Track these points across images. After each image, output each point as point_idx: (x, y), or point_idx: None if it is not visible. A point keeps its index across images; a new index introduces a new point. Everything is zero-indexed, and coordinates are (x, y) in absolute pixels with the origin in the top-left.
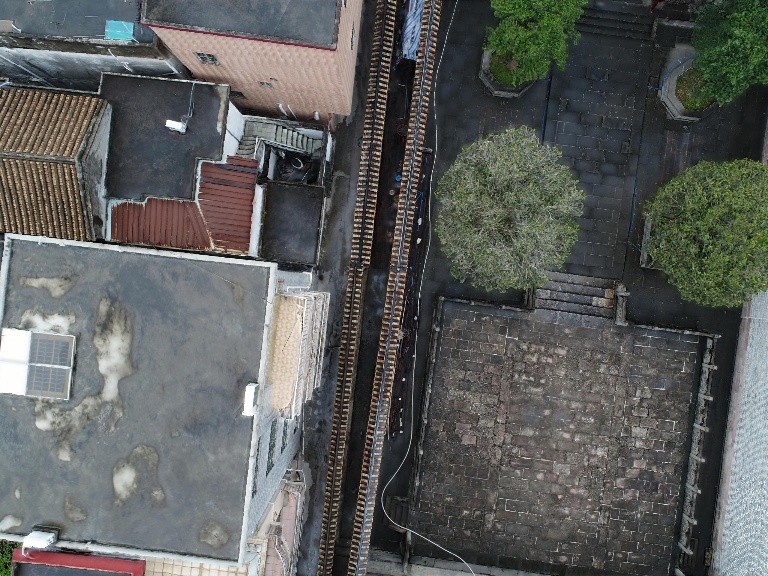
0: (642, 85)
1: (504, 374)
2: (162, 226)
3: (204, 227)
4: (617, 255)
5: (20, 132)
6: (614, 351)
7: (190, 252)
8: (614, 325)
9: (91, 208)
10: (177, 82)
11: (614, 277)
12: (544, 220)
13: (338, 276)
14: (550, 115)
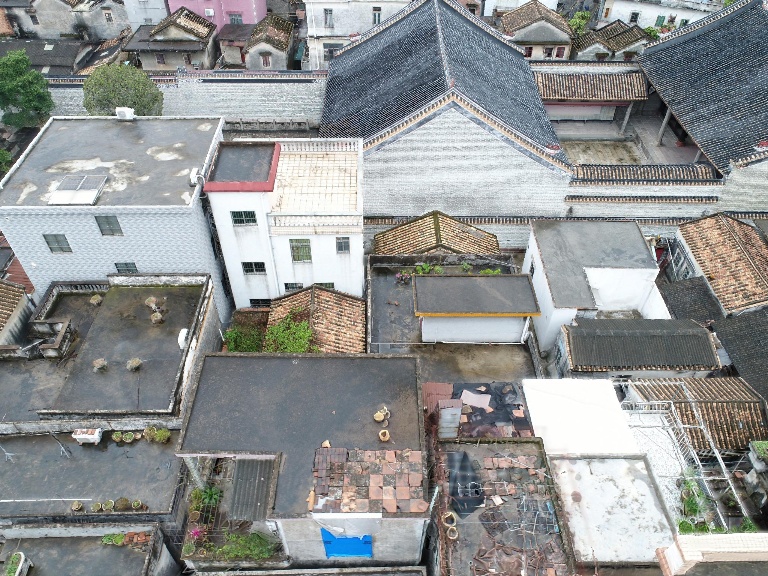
0: None
1: None
2: None
3: None
4: None
5: None
6: None
7: None
8: None
9: None
10: None
11: None
12: None
13: None
14: None
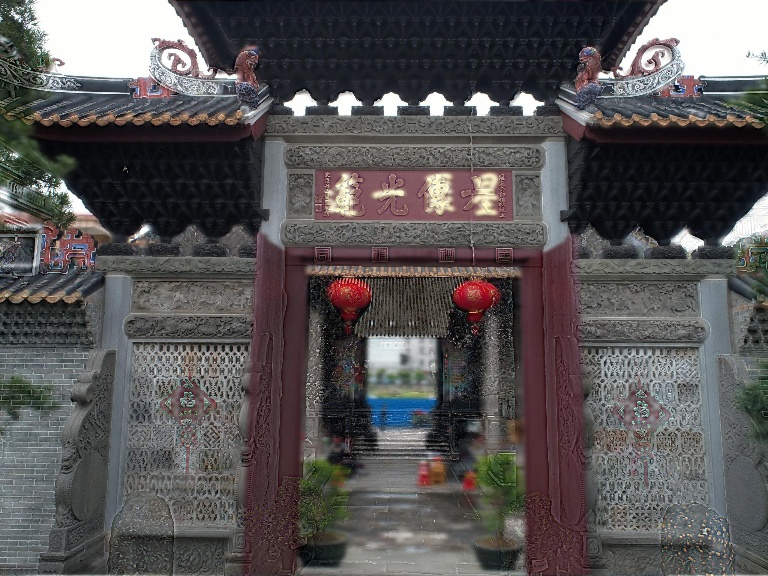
0: None
1: None
2: None
3: None
4: None
5: None
6: None
7: None
8: None
9: None
10: None
11: None
12: None
13: None
14: None
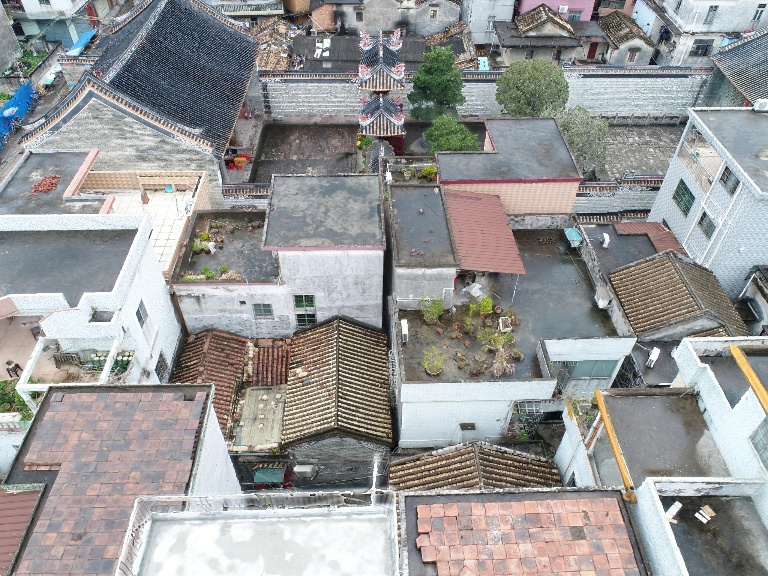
0: None
1: None
2: None
3: None
4: None
5: None
6: None
7: None
8: None
9: None
10: None
11: None
12: None
13: None
14: None
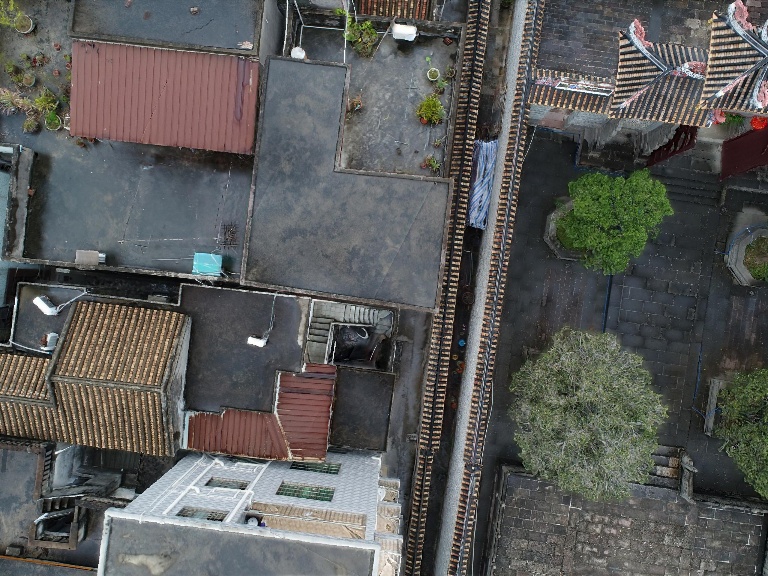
0: (709, 251)
1: (567, 544)
2: (240, 436)
3: (282, 437)
4: (681, 422)
5: (102, 354)
6: (678, 523)
7: (267, 460)
8: (679, 496)
9: (172, 429)
10: (258, 294)
11: (678, 444)
12: (628, 438)
13: (400, 442)
14: (615, 280)
